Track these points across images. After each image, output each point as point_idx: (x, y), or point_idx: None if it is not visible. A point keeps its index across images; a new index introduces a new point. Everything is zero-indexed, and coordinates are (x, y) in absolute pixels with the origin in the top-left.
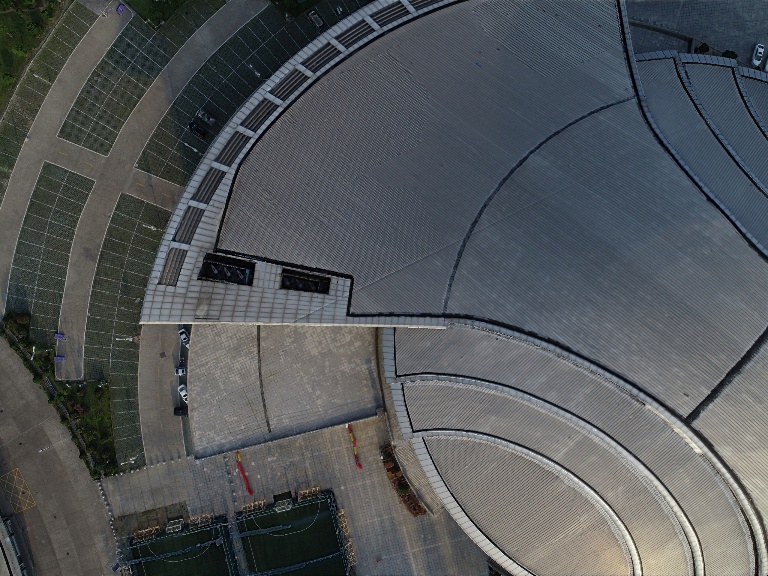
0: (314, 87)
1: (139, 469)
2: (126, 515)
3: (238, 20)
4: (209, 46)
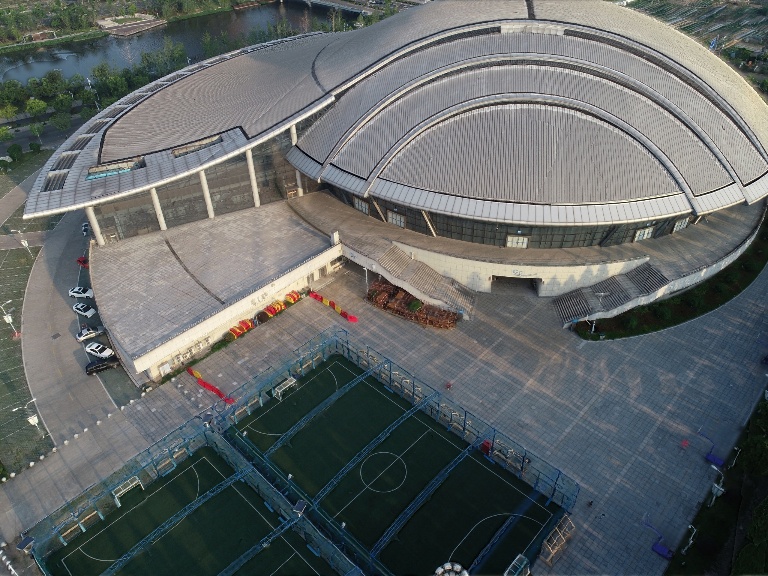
0: (154, 95)
1: (44, 456)
2: None
3: None
4: None
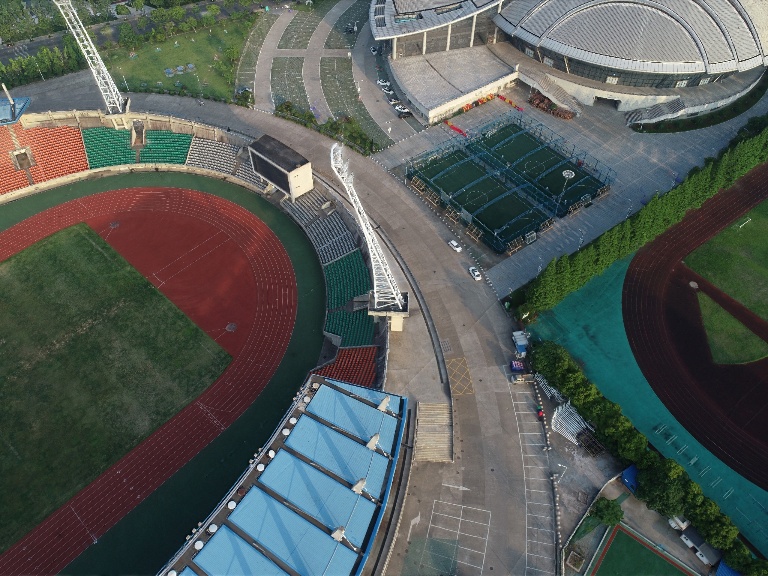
0: None
1: (392, 145)
2: (396, 167)
3: (349, 3)
4: (340, 11)
